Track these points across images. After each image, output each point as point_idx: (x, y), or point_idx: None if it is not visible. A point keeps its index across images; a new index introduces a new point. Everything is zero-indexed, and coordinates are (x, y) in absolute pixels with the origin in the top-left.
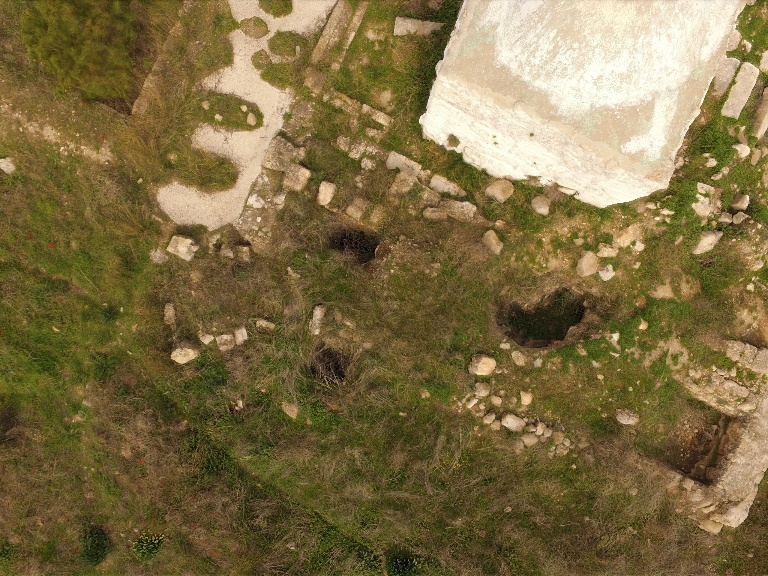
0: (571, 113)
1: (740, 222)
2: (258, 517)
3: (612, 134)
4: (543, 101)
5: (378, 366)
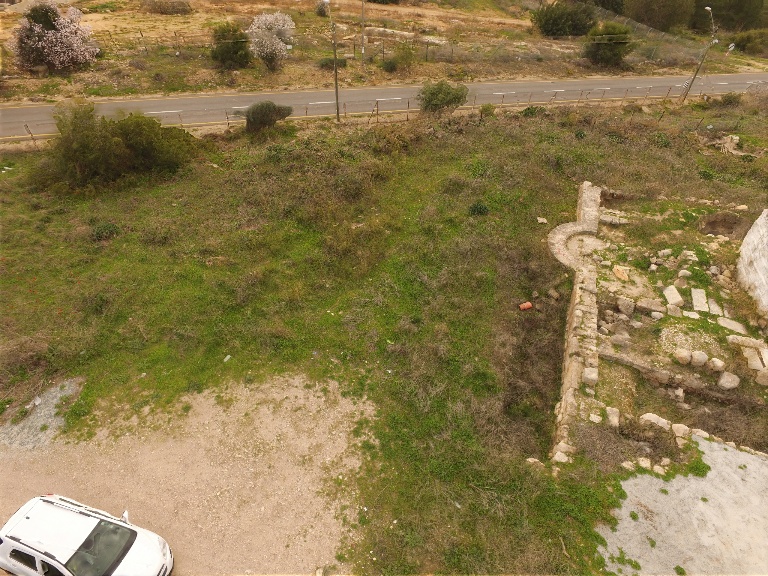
0: None
1: None
2: None
3: None
4: None
5: None
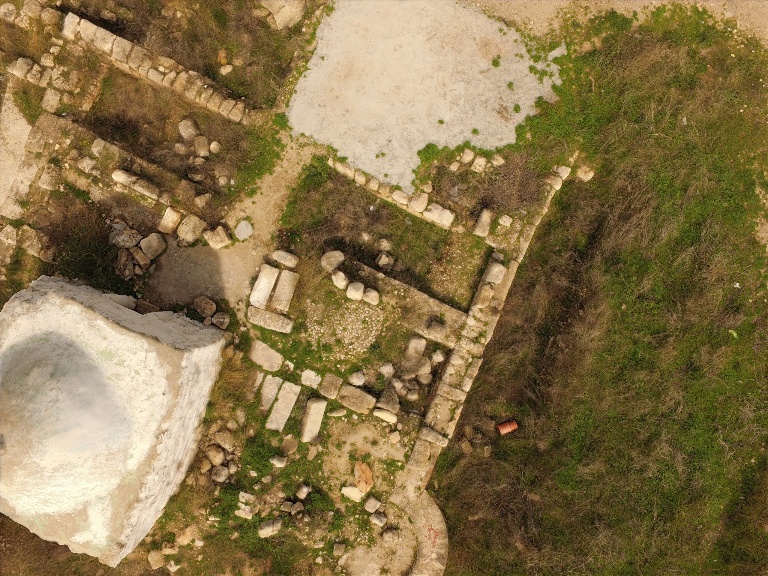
0: (24, 515)
1: (293, 514)
2: None
3: (59, 531)
4: (4, 503)
5: None
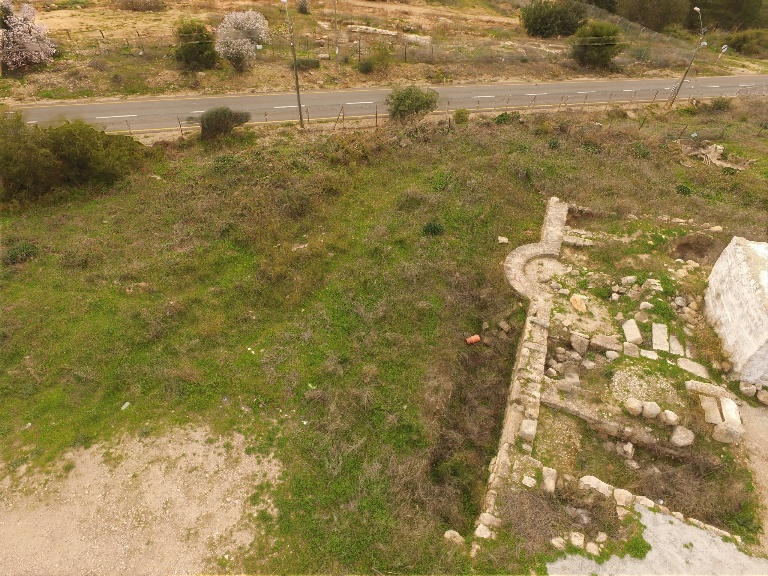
0: None
1: None
2: (759, 201)
3: None
4: None
5: (759, 235)
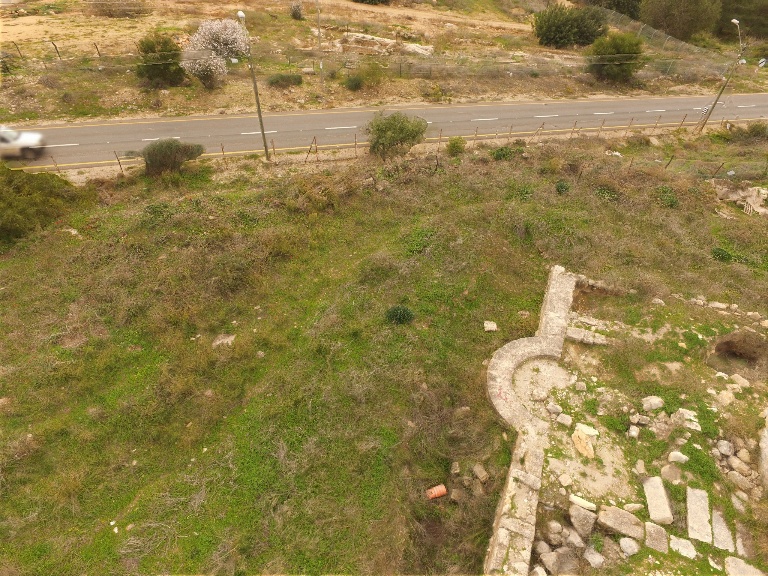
0: None
1: None
2: None
3: None
4: None
5: None
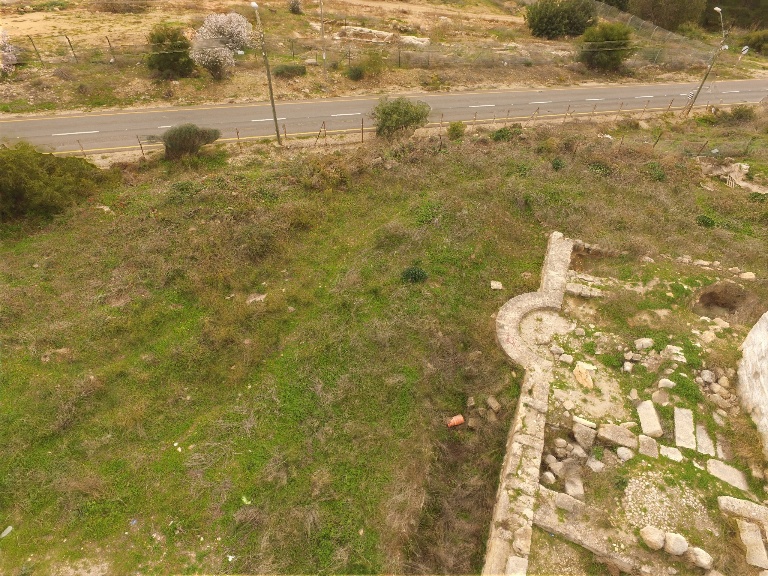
0: None
1: None
2: None
3: None
4: None
5: None
